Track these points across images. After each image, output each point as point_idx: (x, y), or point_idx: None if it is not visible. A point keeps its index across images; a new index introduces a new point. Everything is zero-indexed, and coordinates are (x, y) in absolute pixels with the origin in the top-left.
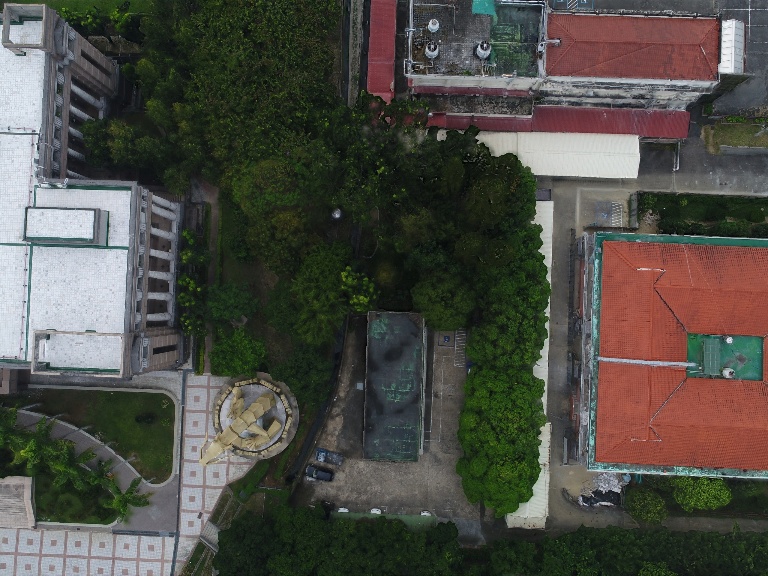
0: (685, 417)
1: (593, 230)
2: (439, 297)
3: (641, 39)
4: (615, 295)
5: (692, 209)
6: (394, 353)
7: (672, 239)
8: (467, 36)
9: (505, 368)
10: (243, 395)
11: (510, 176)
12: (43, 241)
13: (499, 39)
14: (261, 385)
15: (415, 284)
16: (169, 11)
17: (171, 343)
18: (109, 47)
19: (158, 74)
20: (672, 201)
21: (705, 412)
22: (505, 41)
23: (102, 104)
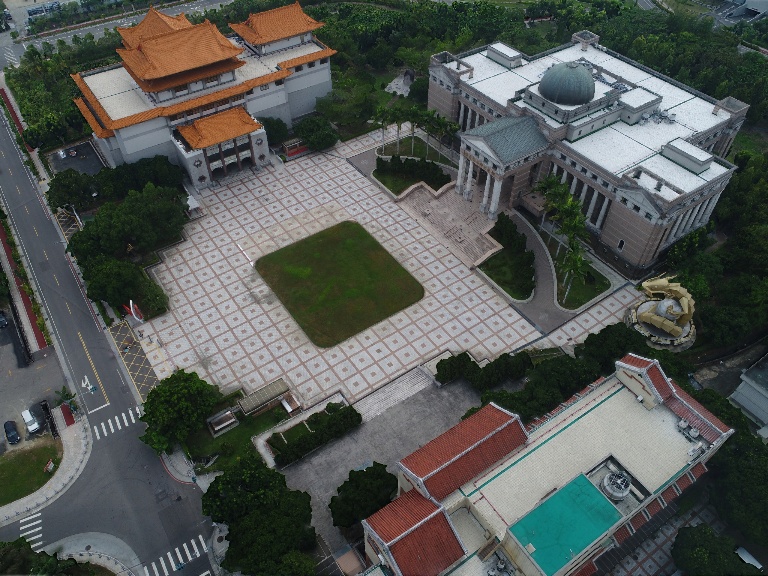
0: None
1: None
2: None
3: None
4: None
5: None
6: None
7: None
8: None
9: None
10: None
11: None
12: (676, 149)
13: None
14: None
15: None
16: None
17: (658, 250)
18: None
19: (761, 168)
20: None
21: None
22: None
23: None
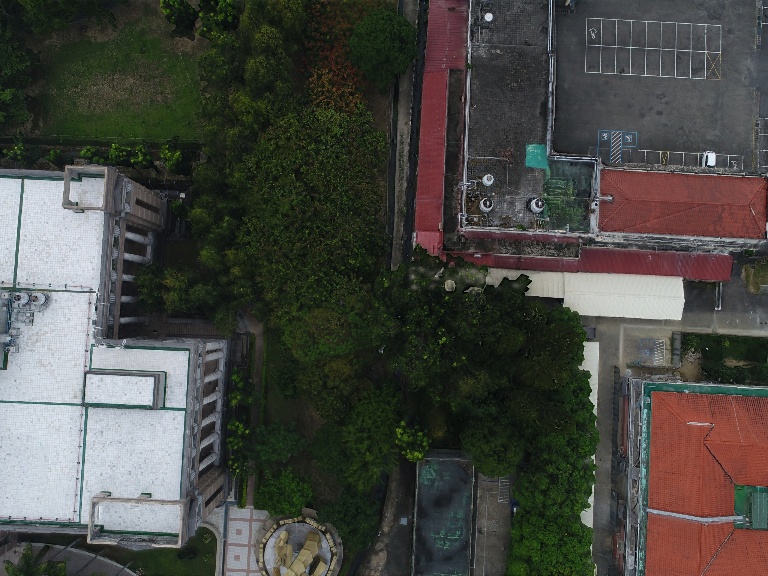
0: (734, 573)
1: (637, 368)
2: (492, 450)
3: (692, 199)
4: (664, 447)
5: (733, 348)
6: (443, 499)
7: (719, 390)
8: (520, 189)
9: (554, 517)
10: (288, 533)
11: (570, 346)
12: (101, 407)
13: (552, 193)
14: (306, 523)
15: (465, 430)
16: (221, 151)
17: (218, 486)
18: (154, 173)
19: (212, 221)
20: (714, 340)
21: (753, 567)
22: (558, 195)
23: (150, 240)
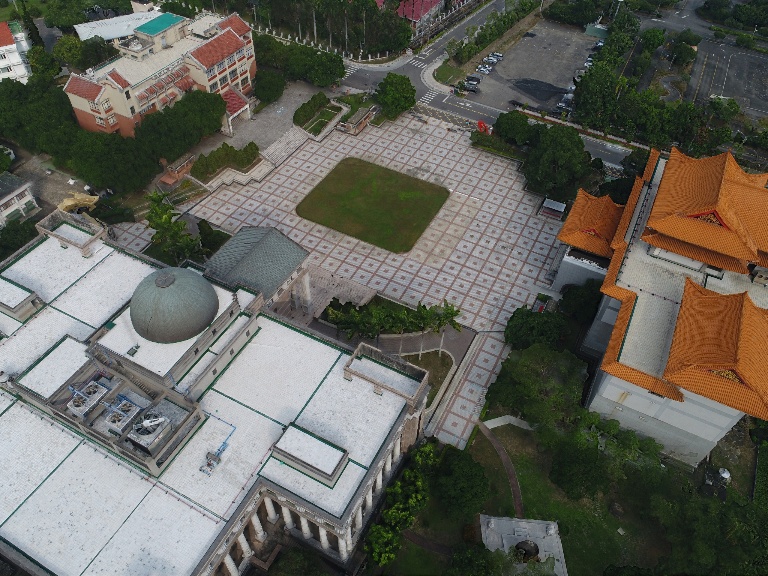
0: None
1: None
2: None
3: None
4: None
5: None
6: None
7: None
8: None
9: None
10: None
11: None
12: None
13: None
14: None
15: None
16: None
17: None
18: None
19: None
20: None
21: None
22: None
23: None
